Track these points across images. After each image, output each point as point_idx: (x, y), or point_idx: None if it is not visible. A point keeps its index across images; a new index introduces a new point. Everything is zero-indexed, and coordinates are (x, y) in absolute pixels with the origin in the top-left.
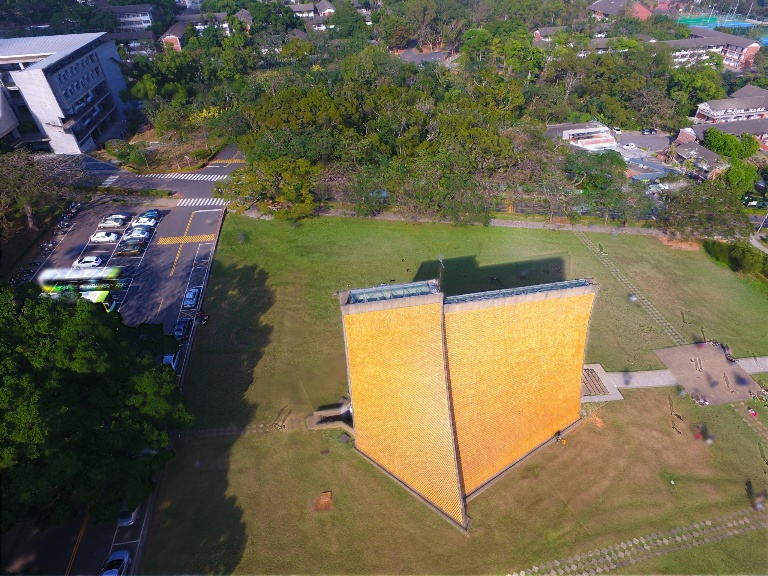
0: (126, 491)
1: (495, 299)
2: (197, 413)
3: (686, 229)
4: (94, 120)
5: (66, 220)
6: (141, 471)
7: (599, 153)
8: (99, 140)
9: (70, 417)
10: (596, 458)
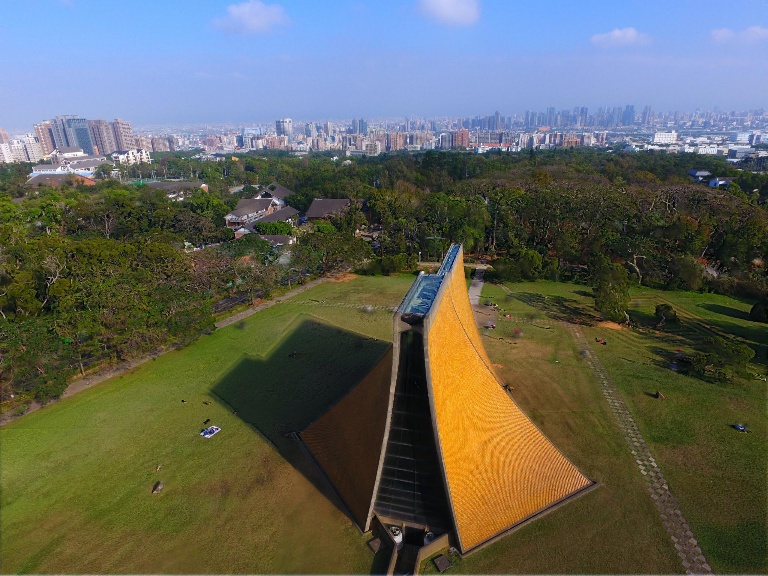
0: None
1: (450, 273)
2: None
3: (351, 260)
4: None
5: None
6: None
7: (241, 239)
8: None
9: None
10: (532, 380)
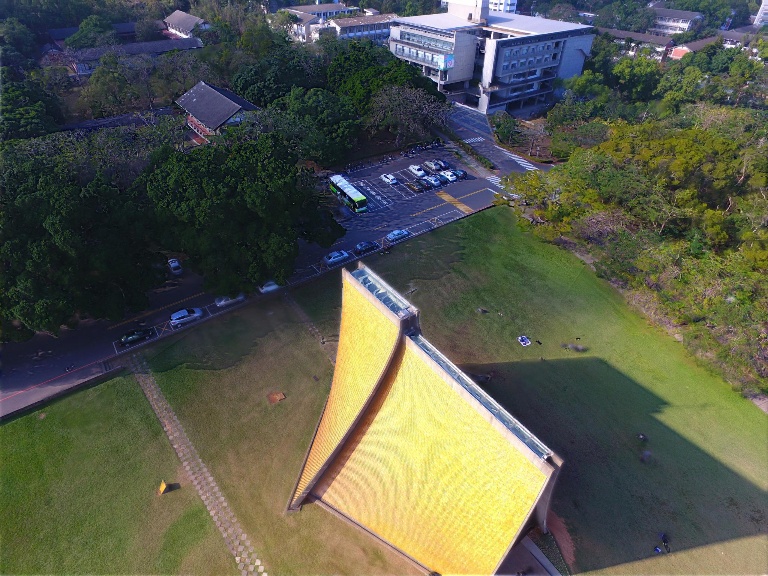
0: (220, 284)
1: (444, 372)
2: (306, 293)
3: None
4: (522, 94)
5: (417, 149)
6: (233, 282)
7: None
8: (515, 111)
9: (227, 224)
10: None
